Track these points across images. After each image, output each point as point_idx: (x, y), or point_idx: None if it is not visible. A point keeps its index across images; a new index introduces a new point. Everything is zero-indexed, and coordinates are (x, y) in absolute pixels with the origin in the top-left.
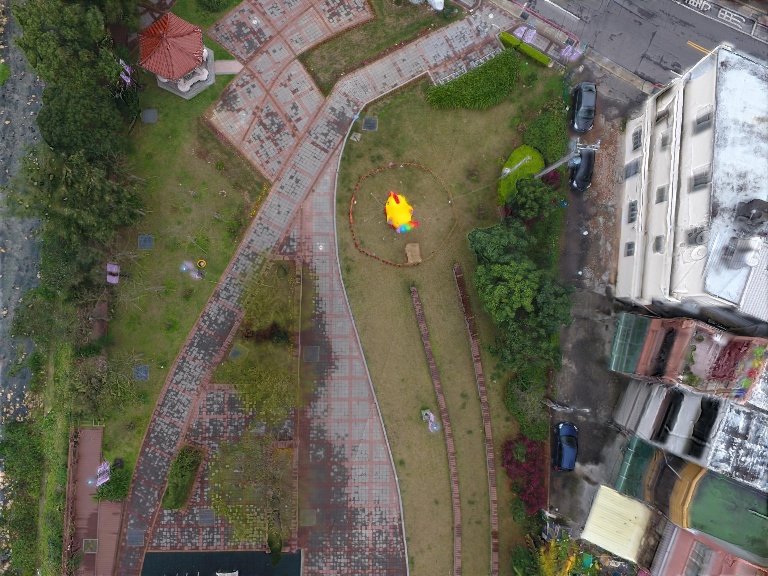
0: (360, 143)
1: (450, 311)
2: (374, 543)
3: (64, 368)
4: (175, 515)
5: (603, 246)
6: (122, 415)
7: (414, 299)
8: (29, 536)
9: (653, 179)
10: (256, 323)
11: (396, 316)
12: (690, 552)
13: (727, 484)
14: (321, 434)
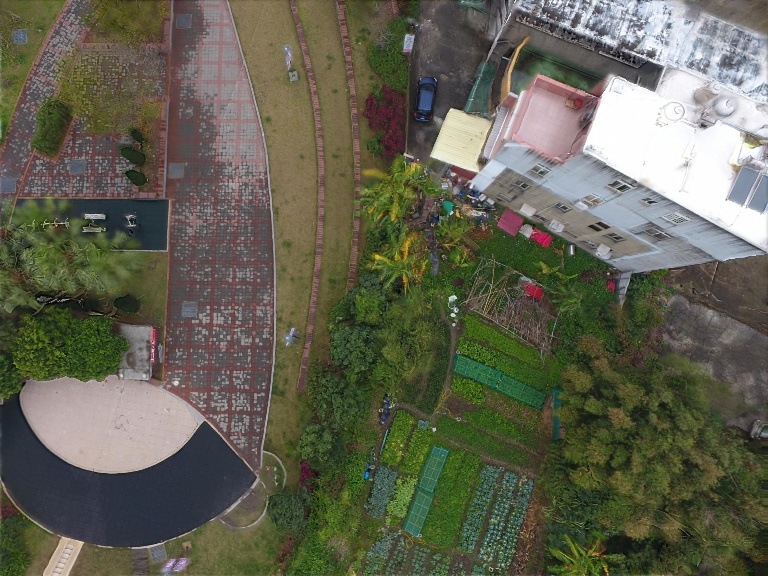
0: None
1: None
2: (240, 195)
3: None
4: (47, 165)
5: None
6: None
7: None
8: None
9: None
10: None
11: None
12: None
13: (557, 66)
14: (191, 94)
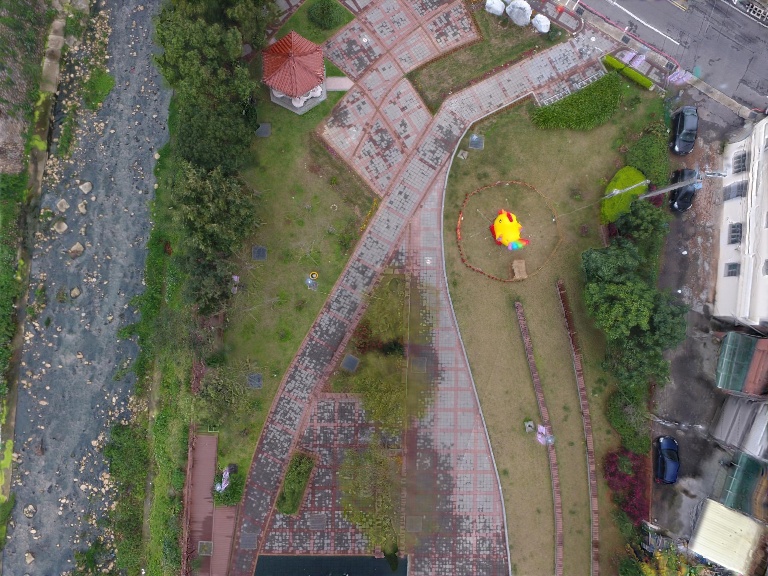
0: (467, 161)
1: (553, 326)
2: (478, 550)
3: (176, 374)
4: (287, 520)
5: (701, 266)
6: (236, 421)
7: (519, 314)
8: (134, 537)
9: (761, 204)
10: (367, 334)
11: (501, 330)
12: None
13: None
14: (428, 443)
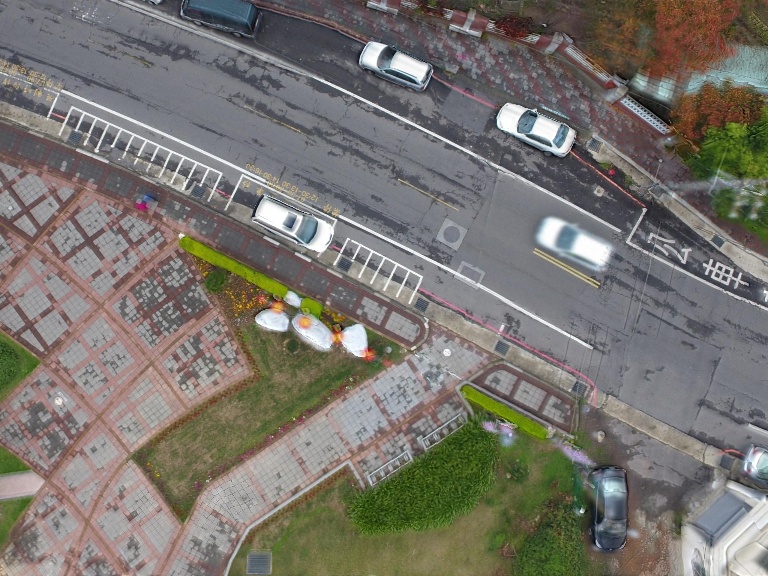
0: None
1: None
2: None
3: None
4: None
5: None
6: None
7: None
8: None
9: None
10: None
11: None
12: None
13: None
14: None
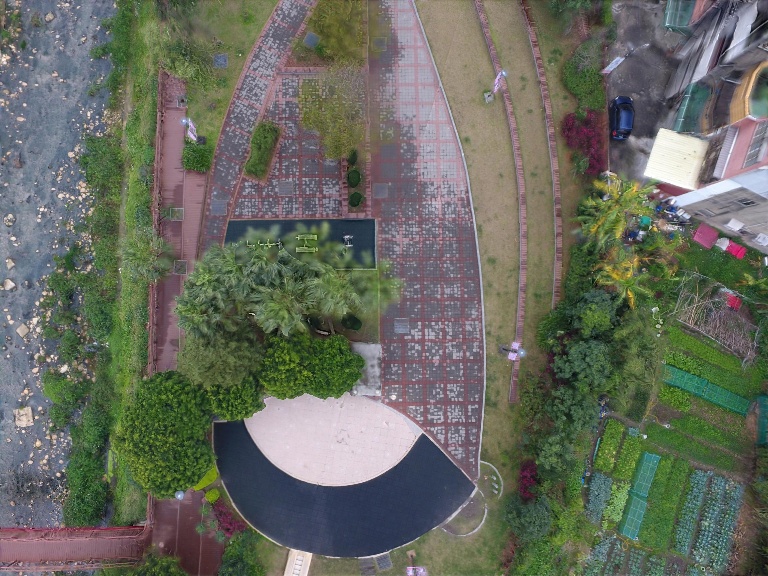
0: None
1: (508, 3)
2: (443, 213)
3: (146, 67)
4: (256, 187)
5: None
6: (204, 98)
7: None
8: (111, 237)
9: None
10: (328, 11)
11: (457, 9)
12: (753, 134)
13: None
14: (390, 115)
